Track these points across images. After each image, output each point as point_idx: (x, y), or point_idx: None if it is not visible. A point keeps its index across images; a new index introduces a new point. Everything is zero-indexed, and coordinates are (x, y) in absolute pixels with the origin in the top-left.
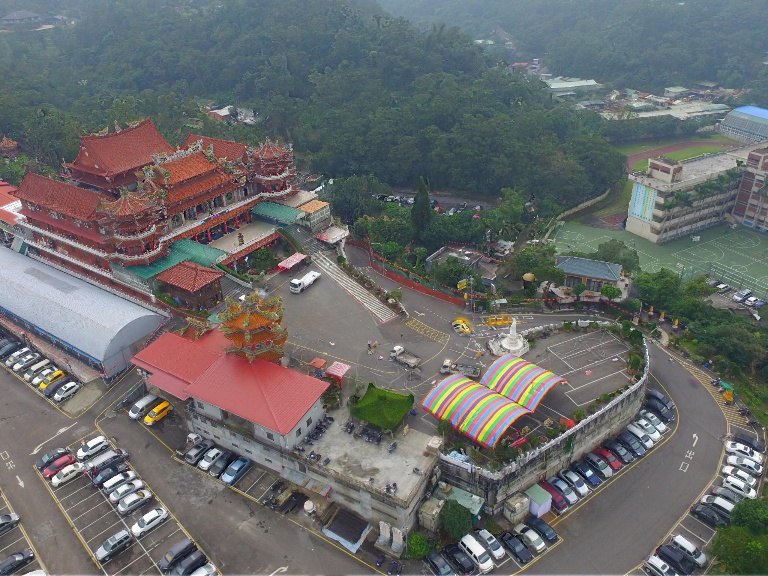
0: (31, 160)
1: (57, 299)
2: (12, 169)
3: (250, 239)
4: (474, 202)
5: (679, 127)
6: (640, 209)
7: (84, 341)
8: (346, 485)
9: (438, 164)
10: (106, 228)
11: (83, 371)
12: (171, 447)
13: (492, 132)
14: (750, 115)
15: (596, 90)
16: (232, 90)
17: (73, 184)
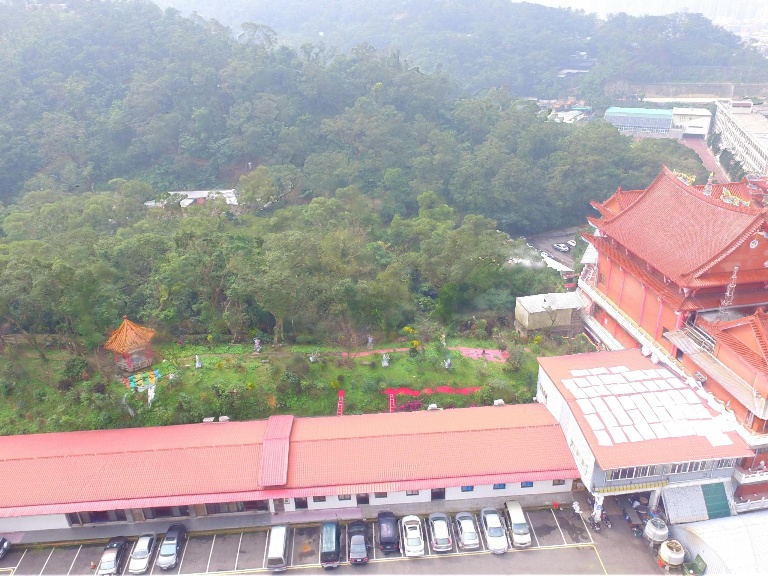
0: (220, 351)
1: None
2: (224, 385)
3: None
4: None
5: None
6: None
7: None
8: None
9: (594, 192)
10: None
11: None
12: None
13: (601, 148)
14: (626, 113)
15: None
16: None
17: (731, 317)
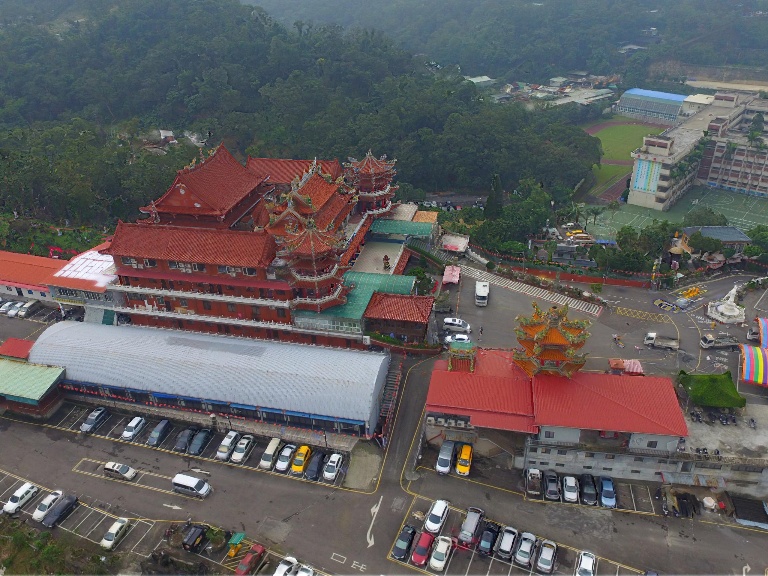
0: (2, 215)
1: (253, 365)
2: None
3: None
4: (483, 197)
5: (591, 111)
6: (643, 183)
7: (329, 404)
8: (744, 470)
9: (442, 165)
10: (277, 272)
11: (331, 440)
12: (513, 490)
13: (480, 129)
14: (642, 96)
15: (491, 85)
16: (150, 112)
17: None
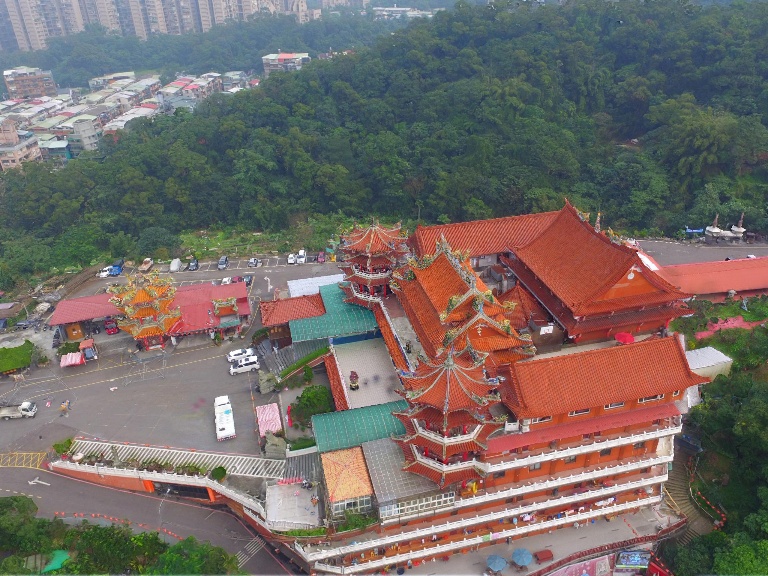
0: None
1: None
2: None
3: (364, 400)
4: None
5: None
6: None
7: None
8: None
9: None
10: None
11: None
12: None
13: None
14: None
15: None
16: None
17: None
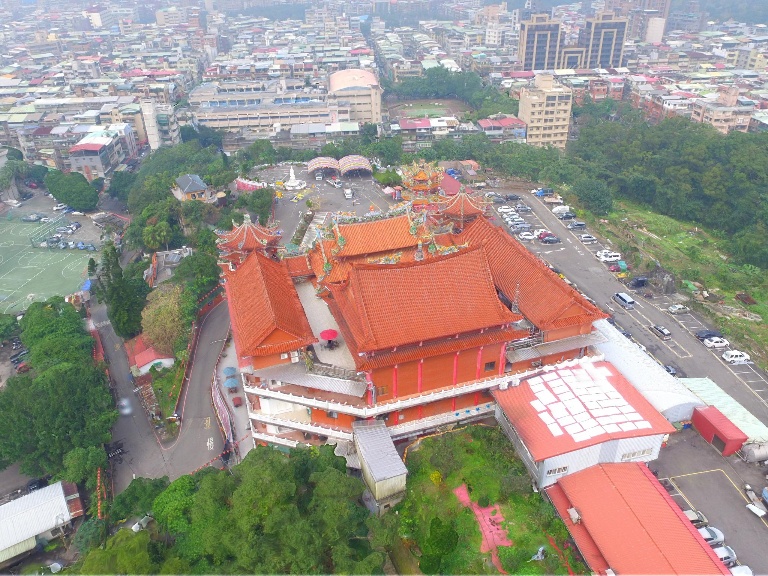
0: None
1: None
2: None
3: None
4: None
5: None
6: None
7: None
8: None
9: None
10: None
11: None
12: None
13: None
14: None
15: None
16: None
17: None
